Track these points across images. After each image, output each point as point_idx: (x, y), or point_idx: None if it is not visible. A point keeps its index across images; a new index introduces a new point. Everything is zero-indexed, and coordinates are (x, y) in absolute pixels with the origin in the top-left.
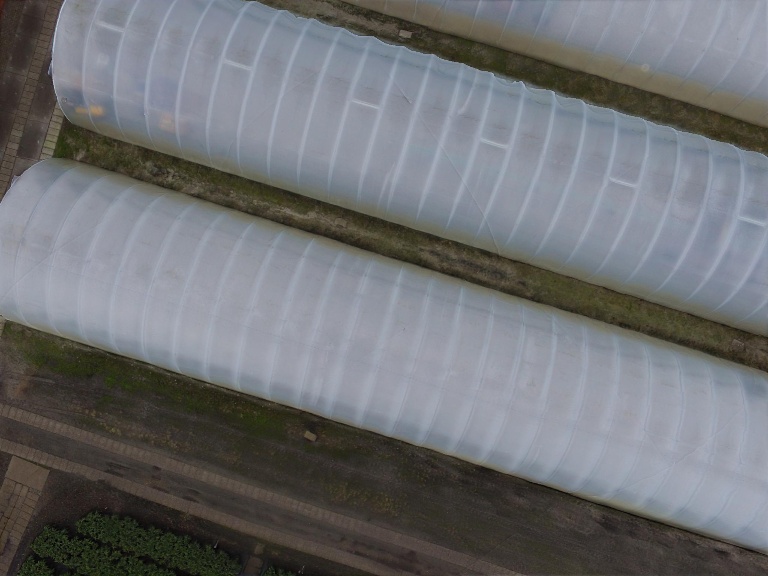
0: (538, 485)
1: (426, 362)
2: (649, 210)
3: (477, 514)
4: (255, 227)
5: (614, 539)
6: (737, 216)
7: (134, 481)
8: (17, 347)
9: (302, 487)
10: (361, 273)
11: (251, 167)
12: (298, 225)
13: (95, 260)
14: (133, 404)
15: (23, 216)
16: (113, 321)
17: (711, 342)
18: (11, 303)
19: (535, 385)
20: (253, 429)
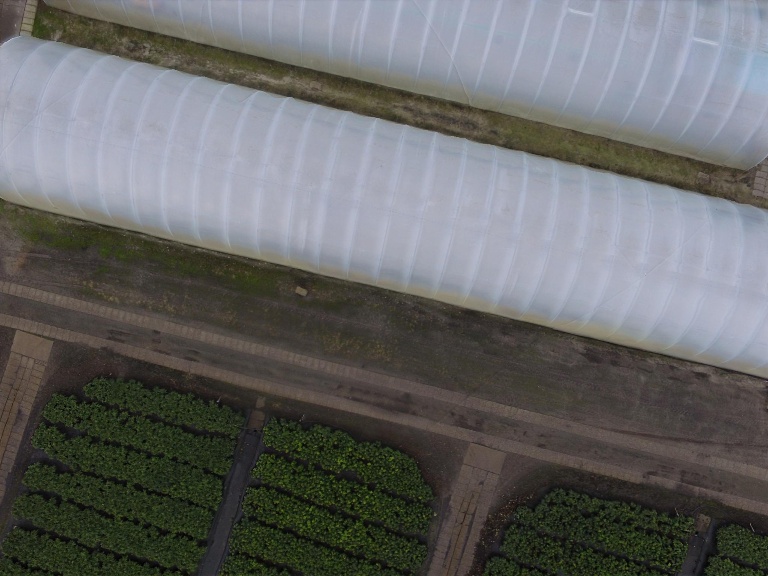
0: (521, 322)
1: (404, 195)
2: (608, 36)
3: (465, 354)
4: (232, 88)
5: (596, 368)
6: (692, 36)
7: (135, 346)
8: (12, 226)
9: (297, 340)
10: (337, 120)
11: (224, 32)
12: (275, 90)
13: (79, 119)
14: (128, 273)
15: (6, 82)
16: (102, 179)
17: (678, 176)
18: (2, 172)
19: (509, 210)
20: (246, 288)
